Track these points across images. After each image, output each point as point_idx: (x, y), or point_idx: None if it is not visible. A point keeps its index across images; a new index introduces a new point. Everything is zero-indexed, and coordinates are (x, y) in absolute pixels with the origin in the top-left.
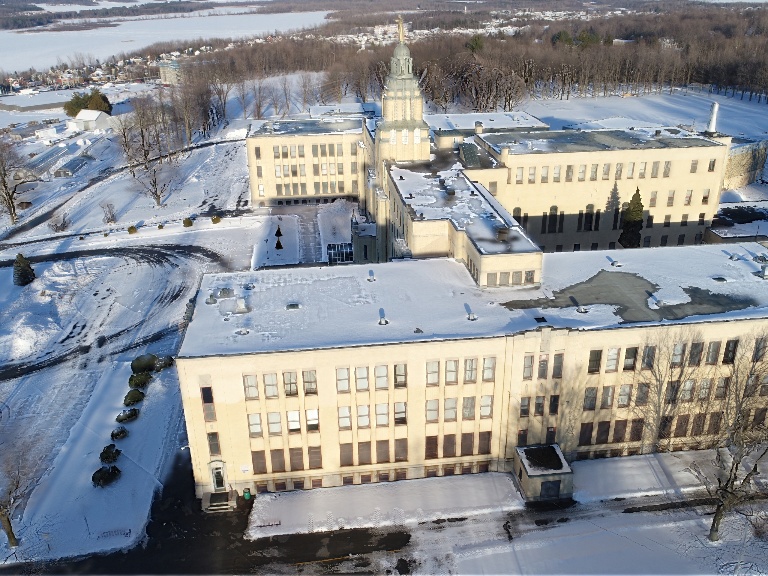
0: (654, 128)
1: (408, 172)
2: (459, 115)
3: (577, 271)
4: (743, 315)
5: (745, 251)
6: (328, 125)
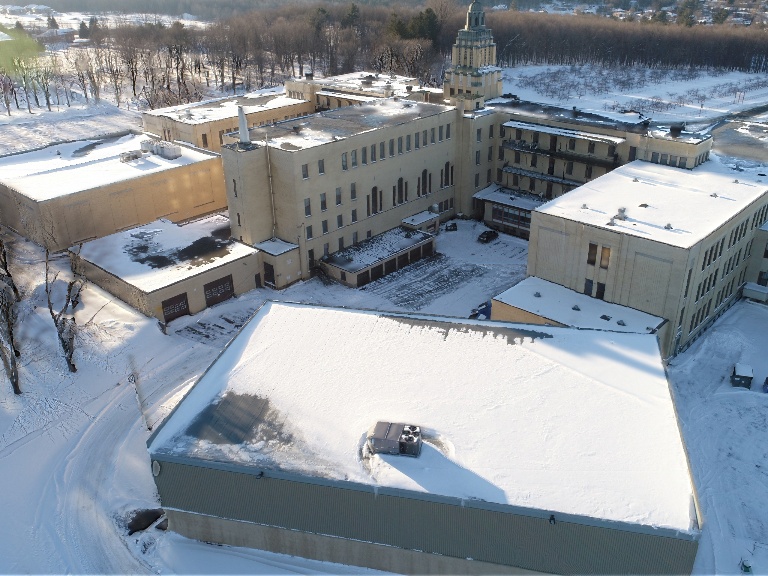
0: (315, 144)
1: (430, 90)
2: (725, 205)
3: (277, 102)
4: (198, 103)
5: (199, 120)
6: (761, 148)
